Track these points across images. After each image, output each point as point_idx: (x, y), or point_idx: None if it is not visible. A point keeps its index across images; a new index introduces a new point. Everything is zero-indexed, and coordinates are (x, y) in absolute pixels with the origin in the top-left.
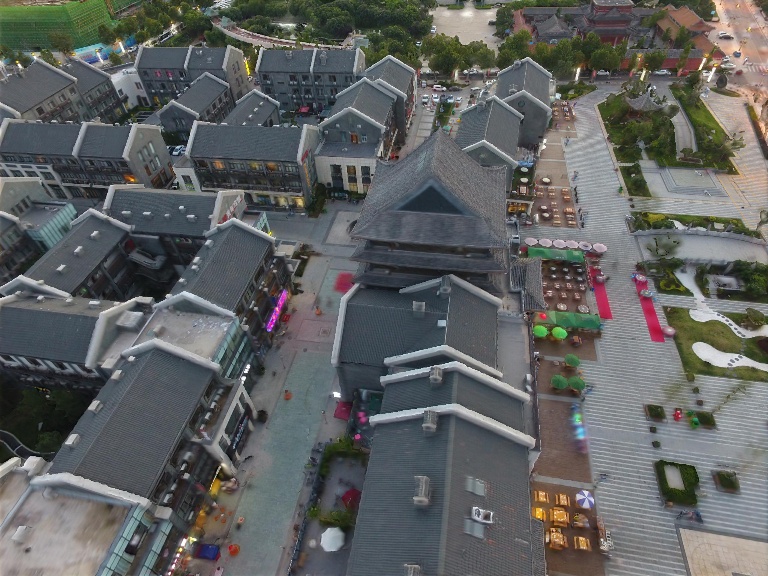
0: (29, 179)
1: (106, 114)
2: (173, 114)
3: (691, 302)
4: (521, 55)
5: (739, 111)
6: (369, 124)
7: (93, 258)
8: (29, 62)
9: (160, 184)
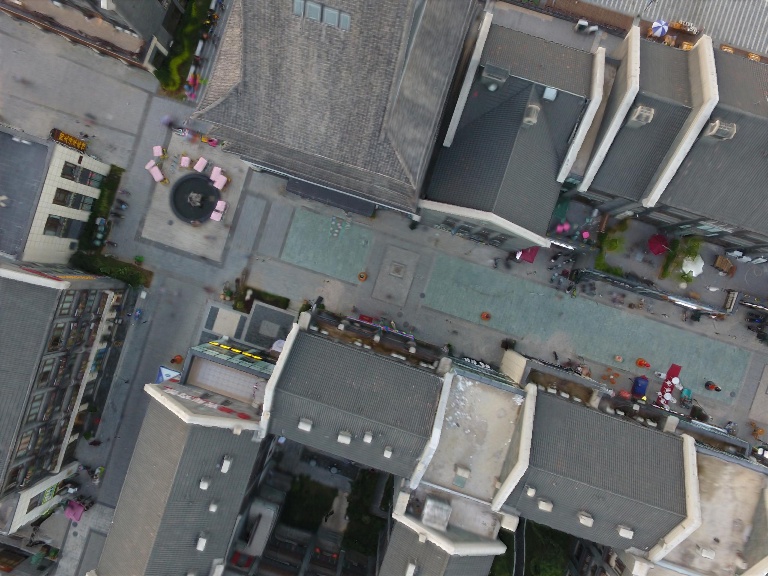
0: None
1: None
2: None
3: None
4: None
5: None
6: None
7: None
8: None
9: (5, 556)
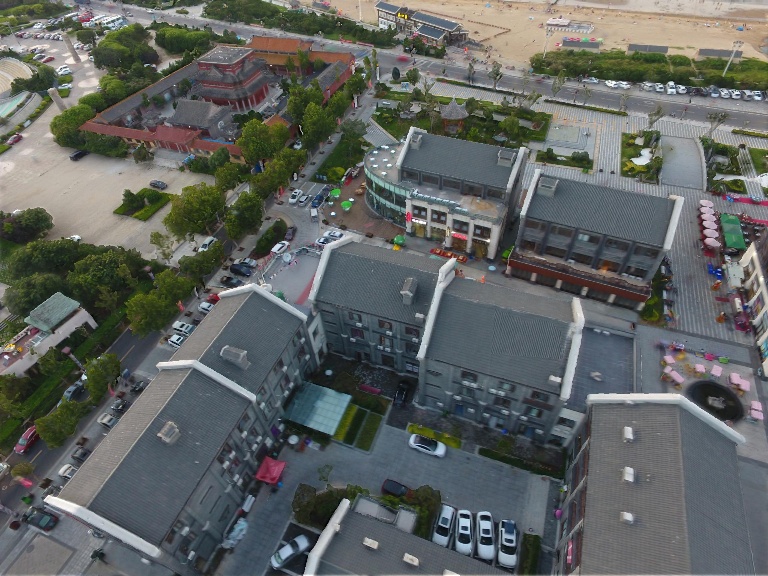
0: None
1: None
2: None
3: (752, 183)
4: (278, 149)
5: (441, 85)
6: None
7: None
8: None
9: None
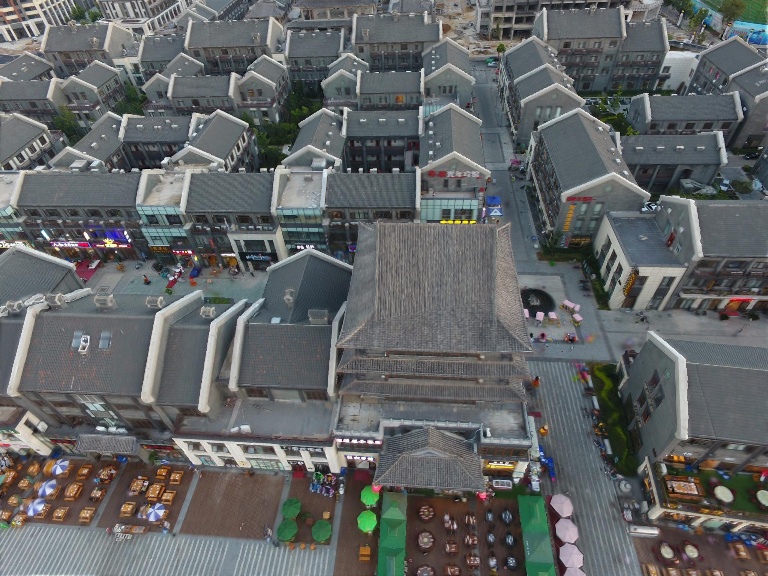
0: (467, 76)
1: (628, 79)
2: (639, 106)
3: None
4: None
5: None
6: (691, 236)
7: (383, 131)
8: (690, 15)
9: None
